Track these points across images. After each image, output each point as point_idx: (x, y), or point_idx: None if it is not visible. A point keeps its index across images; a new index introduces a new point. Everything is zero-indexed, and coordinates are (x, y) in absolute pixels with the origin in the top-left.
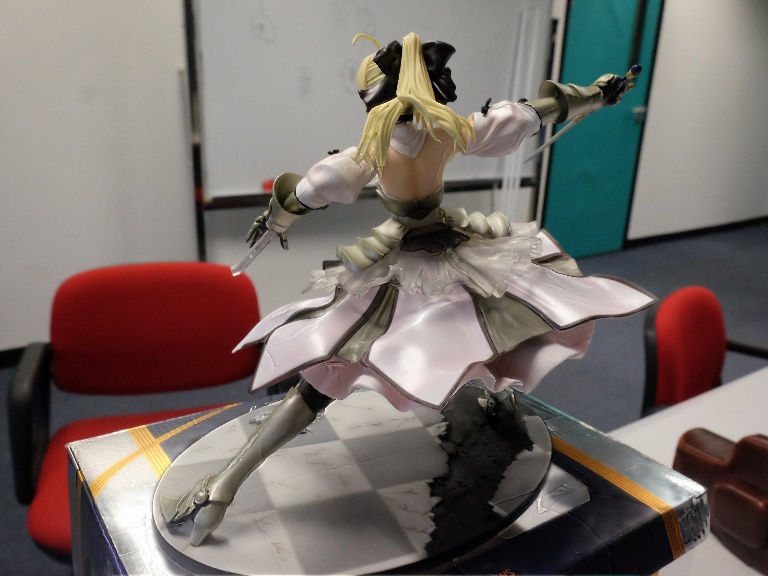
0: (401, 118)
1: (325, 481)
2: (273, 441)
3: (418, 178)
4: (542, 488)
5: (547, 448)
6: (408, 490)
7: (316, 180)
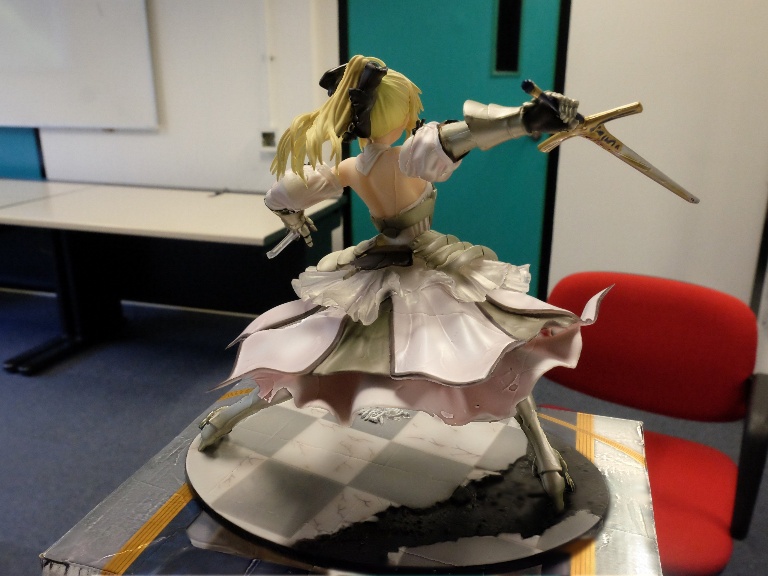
0: (344, 136)
1: (328, 460)
2: (259, 398)
3: (378, 196)
4: (486, 575)
5: (544, 546)
6: (367, 500)
7: (273, 186)
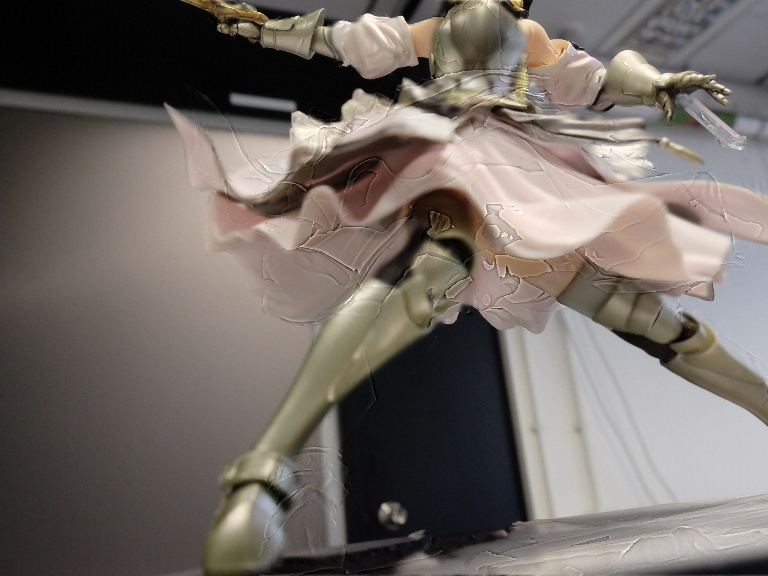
0: None
1: None
2: None
3: None
4: None
5: None
6: None
7: None
